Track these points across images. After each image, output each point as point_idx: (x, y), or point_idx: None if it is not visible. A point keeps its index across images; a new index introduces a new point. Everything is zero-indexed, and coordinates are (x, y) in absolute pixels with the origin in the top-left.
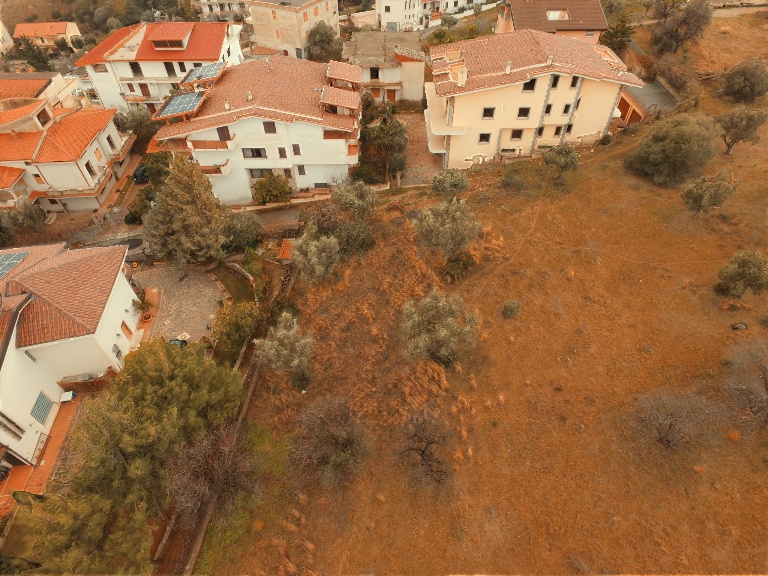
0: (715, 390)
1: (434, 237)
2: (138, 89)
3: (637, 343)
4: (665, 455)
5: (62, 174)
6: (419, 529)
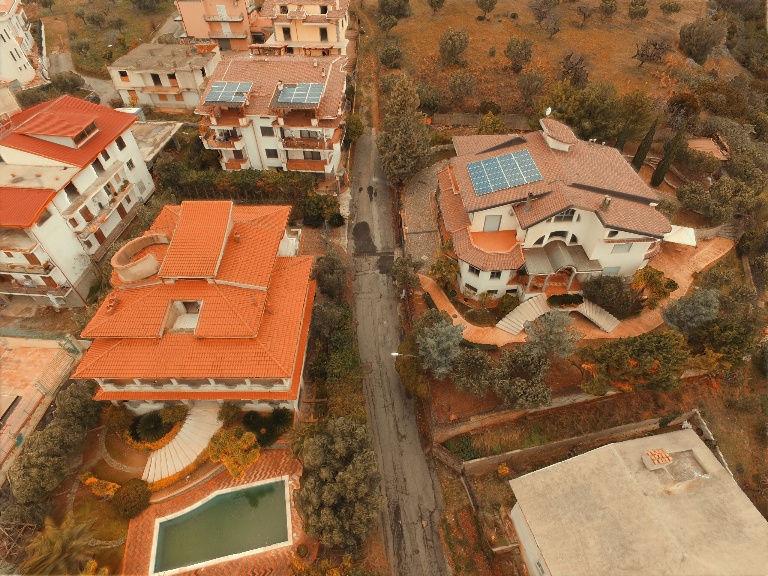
0: (528, 29)
1: (463, 45)
2: (79, 218)
3: (508, 36)
4: (554, 40)
5: (282, 240)
6: (590, 80)
